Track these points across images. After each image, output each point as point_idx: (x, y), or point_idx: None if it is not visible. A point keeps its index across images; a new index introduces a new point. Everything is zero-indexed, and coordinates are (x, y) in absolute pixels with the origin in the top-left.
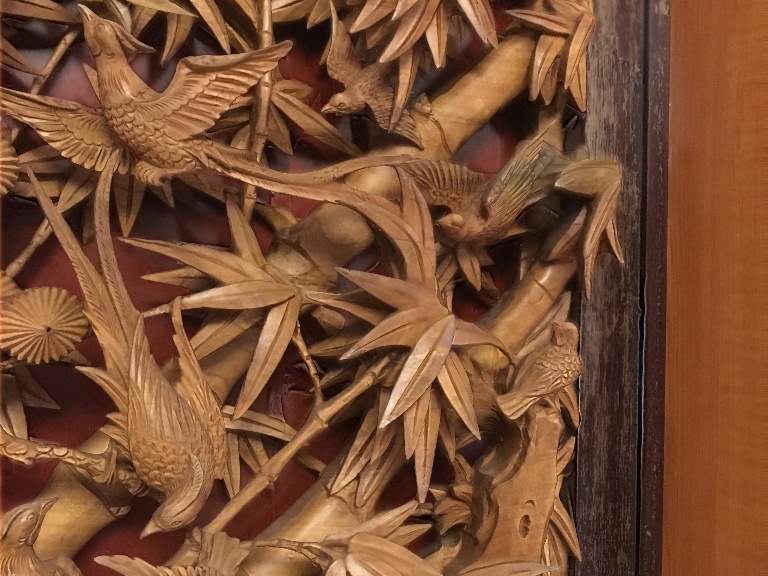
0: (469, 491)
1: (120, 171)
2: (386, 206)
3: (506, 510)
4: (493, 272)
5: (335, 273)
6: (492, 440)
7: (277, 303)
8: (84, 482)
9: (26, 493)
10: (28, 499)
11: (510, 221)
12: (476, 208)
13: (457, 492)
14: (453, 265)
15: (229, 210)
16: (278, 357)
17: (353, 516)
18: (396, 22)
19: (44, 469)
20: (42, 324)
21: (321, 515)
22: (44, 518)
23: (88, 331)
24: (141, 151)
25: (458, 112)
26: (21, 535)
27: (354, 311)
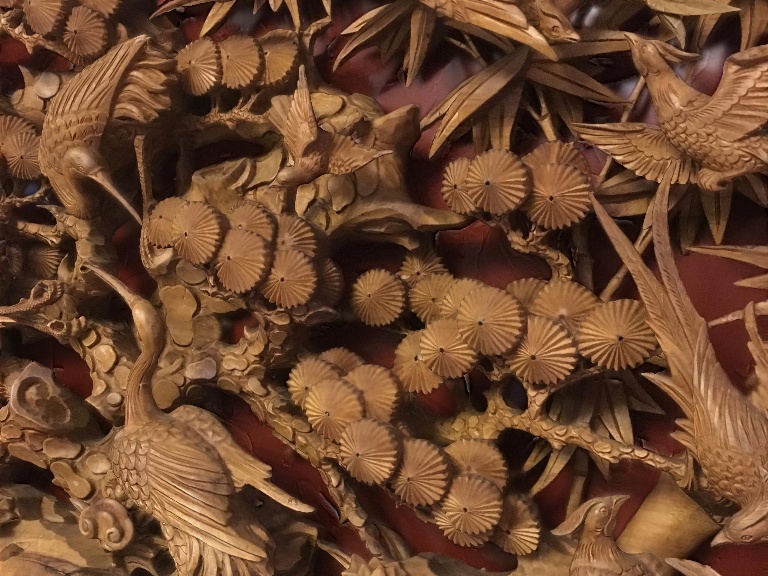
0: None
1: (692, 181)
2: None
3: None
4: None
5: None
6: None
7: None
8: None
9: (640, 491)
10: (642, 497)
11: None
12: None
13: None
14: None
15: None
16: None
17: None
18: None
19: (655, 471)
20: (614, 334)
21: None
22: (650, 516)
23: None
24: (699, 158)
25: None
26: (596, 525)
27: None
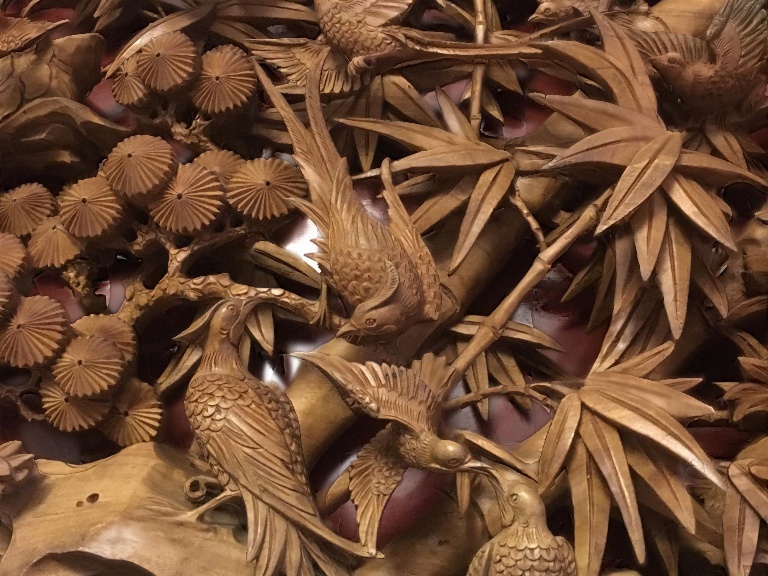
0: (763, 364)
1: (345, 89)
2: None
3: None
4: (766, 163)
5: None
6: None
7: (488, 164)
8: None
9: None
10: None
11: (752, 70)
12: (703, 58)
13: (745, 364)
14: (704, 146)
15: (439, 100)
16: (491, 207)
17: None
18: None
19: None
20: (262, 179)
21: None
22: None
23: None
24: (350, 48)
25: (681, 7)
26: (222, 325)
27: None
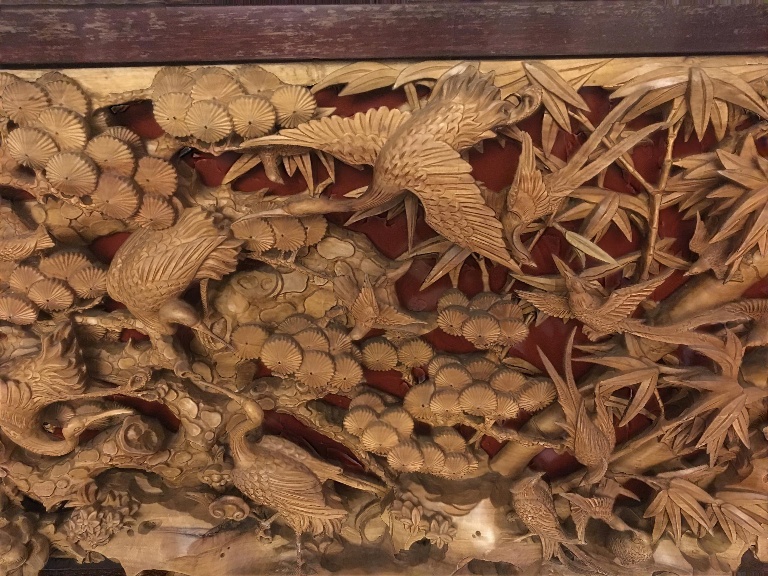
0: (737, 450)
1: (571, 317)
2: (716, 342)
3: (758, 470)
4: None
5: (677, 345)
6: (756, 428)
7: None
8: (543, 435)
9: (514, 427)
10: None
11: None
12: None
13: None
14: None
15: (626, 335)
16: (645, 404)
17: (670, 452)
18: (739, 238)
19: (521, 418)
20: (538, 401)
21: (654, 450)
22: None
23: (555, 396)
24: (587, 324)
25: None
26: (532, 486)
27: (688, 385)
